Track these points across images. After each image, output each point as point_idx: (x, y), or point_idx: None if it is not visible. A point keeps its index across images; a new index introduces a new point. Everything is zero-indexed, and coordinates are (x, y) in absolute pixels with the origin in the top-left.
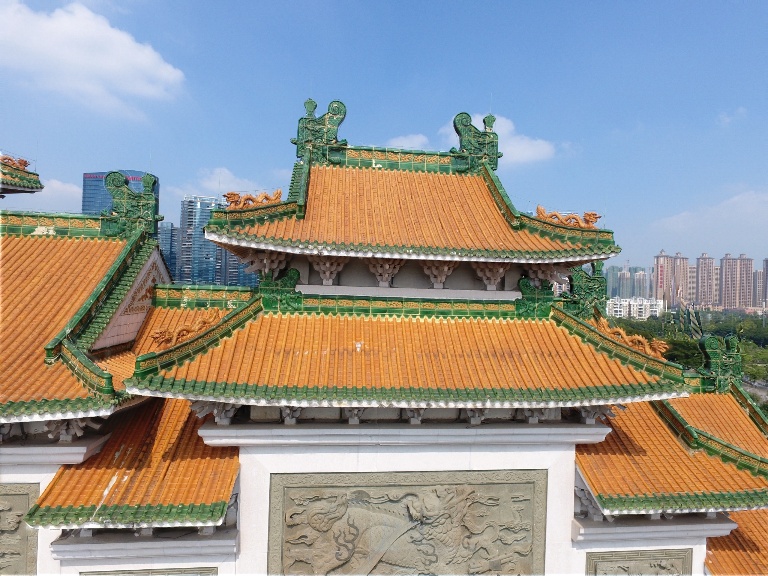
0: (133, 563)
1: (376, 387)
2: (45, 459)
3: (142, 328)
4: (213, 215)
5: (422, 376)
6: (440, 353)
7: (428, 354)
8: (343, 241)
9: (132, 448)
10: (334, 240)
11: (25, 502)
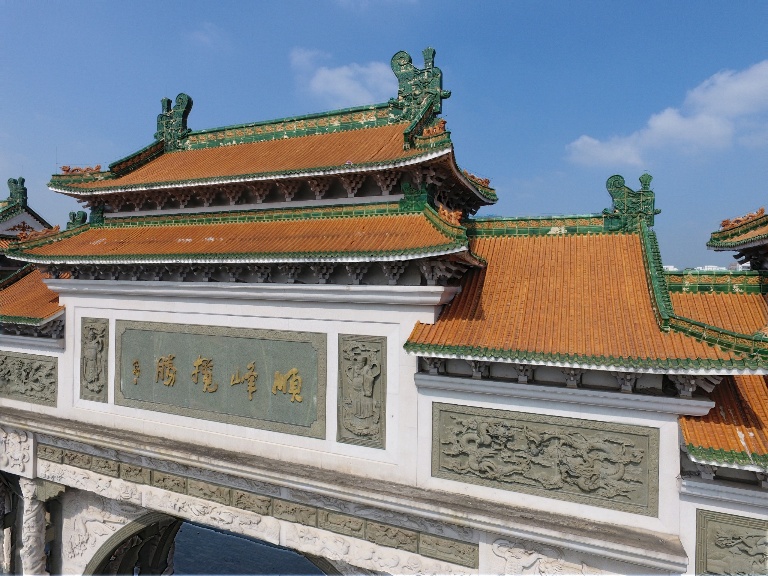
0: (749, 511)
1: None
2: (673, 409)
3: None
4: None
5: None
6: None
7: None
8: None
9: (732, 410)
10: None
11: (645, 442)
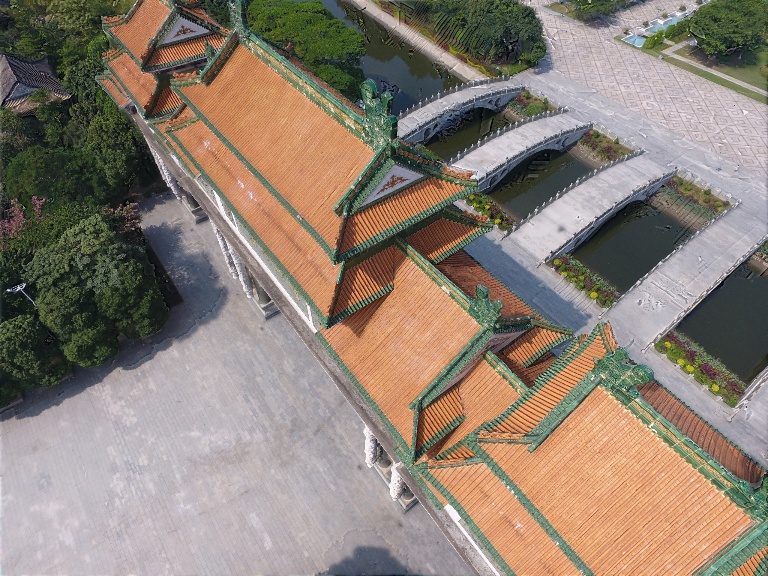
0: None
1: (502, 555)
2: None
3: (471, 371)
4: (468, 438)
5: (528, 573)
6: (552, 574)
7: (546, 567)
8: (529, 498)
9: None
10: (525, 493)
11: None
